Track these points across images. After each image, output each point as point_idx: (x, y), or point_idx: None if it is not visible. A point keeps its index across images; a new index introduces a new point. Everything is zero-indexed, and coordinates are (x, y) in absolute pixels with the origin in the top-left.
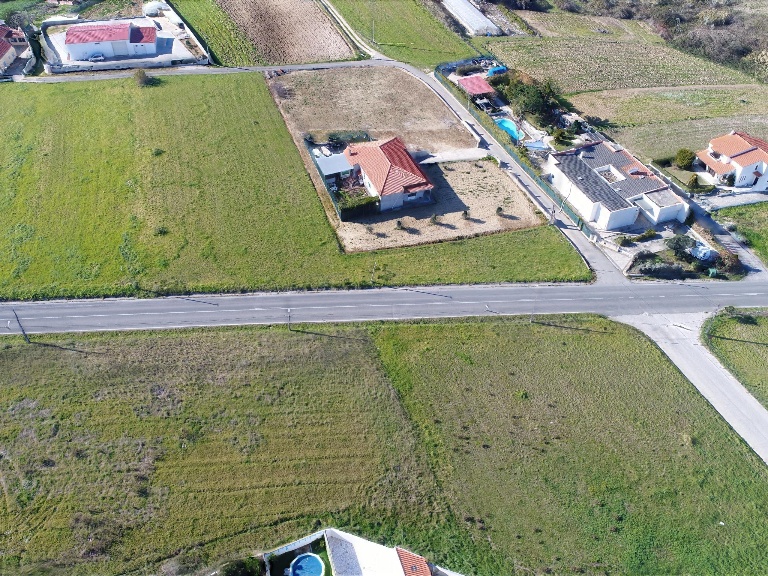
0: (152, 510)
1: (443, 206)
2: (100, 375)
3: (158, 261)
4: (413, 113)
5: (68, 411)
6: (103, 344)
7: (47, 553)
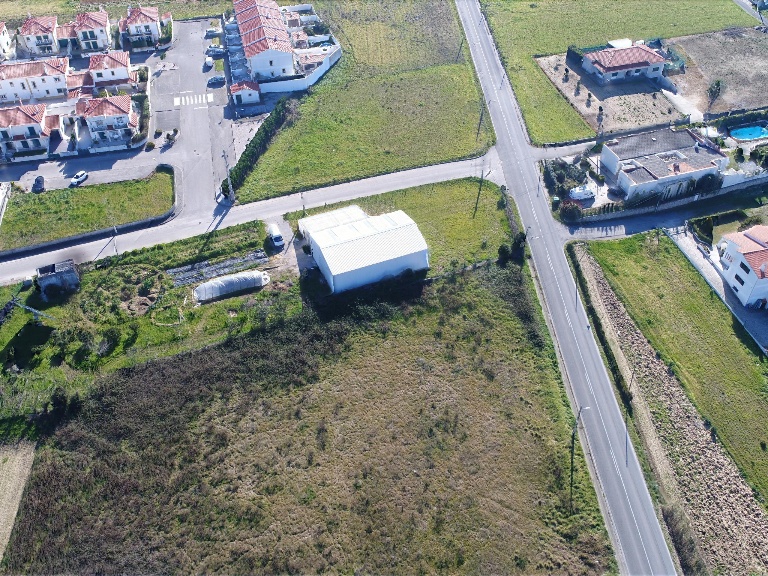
0: (359, 22)
1: (599, 90)
2: (428, 5)
3: (507, 7)
4: (743, 87)
5: (407, 2)
6: (447, 4)
7: (344, 8)
